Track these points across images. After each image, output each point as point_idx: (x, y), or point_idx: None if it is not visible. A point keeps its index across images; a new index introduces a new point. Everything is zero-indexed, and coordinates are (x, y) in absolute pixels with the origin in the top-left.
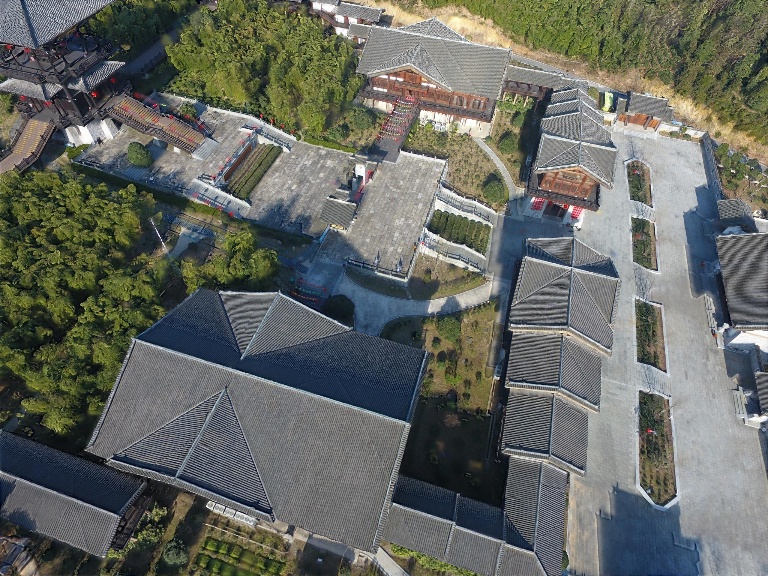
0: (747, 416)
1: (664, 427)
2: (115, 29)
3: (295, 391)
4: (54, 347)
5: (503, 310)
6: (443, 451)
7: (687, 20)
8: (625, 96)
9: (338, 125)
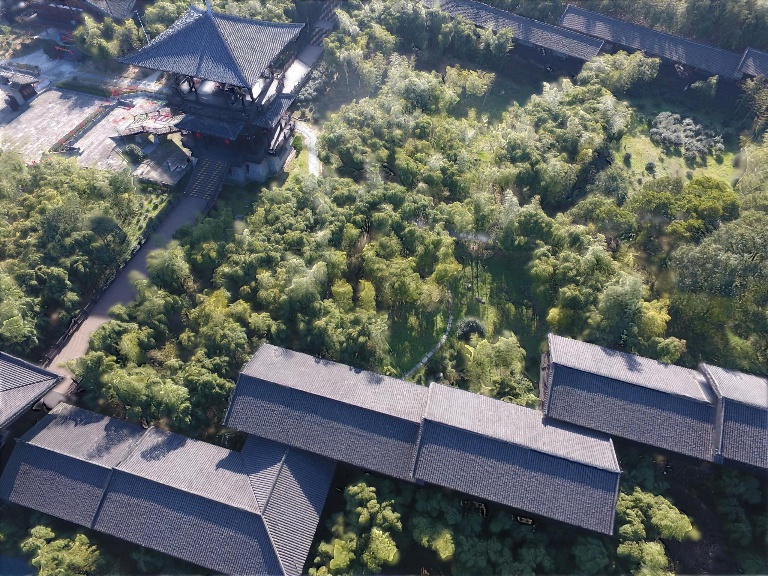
0: None
1: None
2: None
3: None
4: None
5: None
6: None
7: None
8: None
9: None
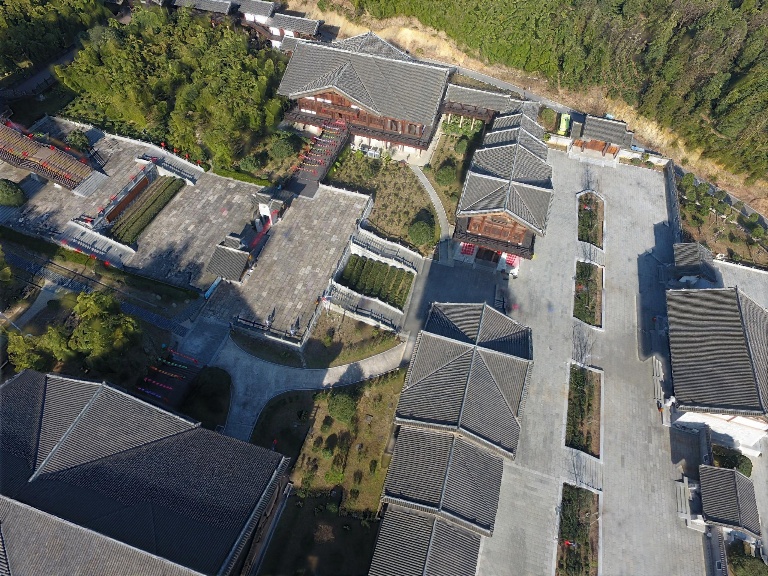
0: (690, 516)
1: (590, 531)
2: (7, 45)
3: (84, 530)
4: None
5: None
6: (315, 569)
7: (657, 33)
8: None
9: (256, 152)
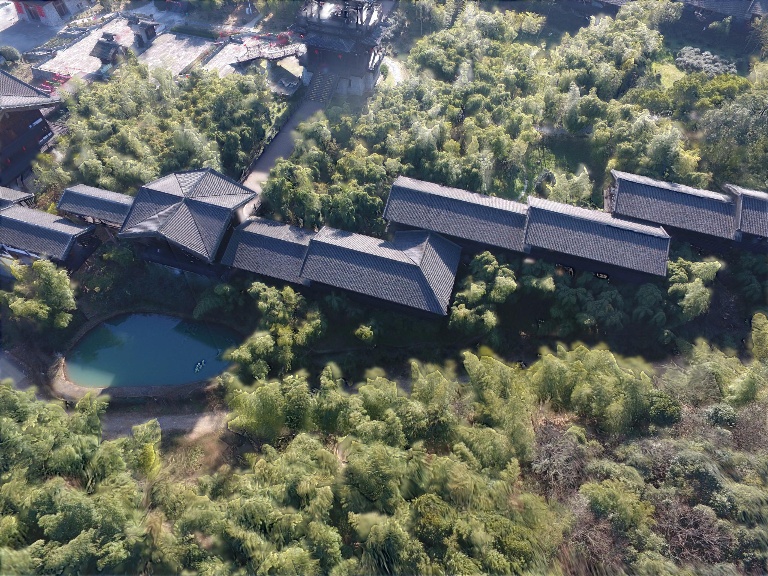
0: None
1: None
2: None
3: None
4: None
5: (68, 19)
6: None
7: None
8: None
9: None
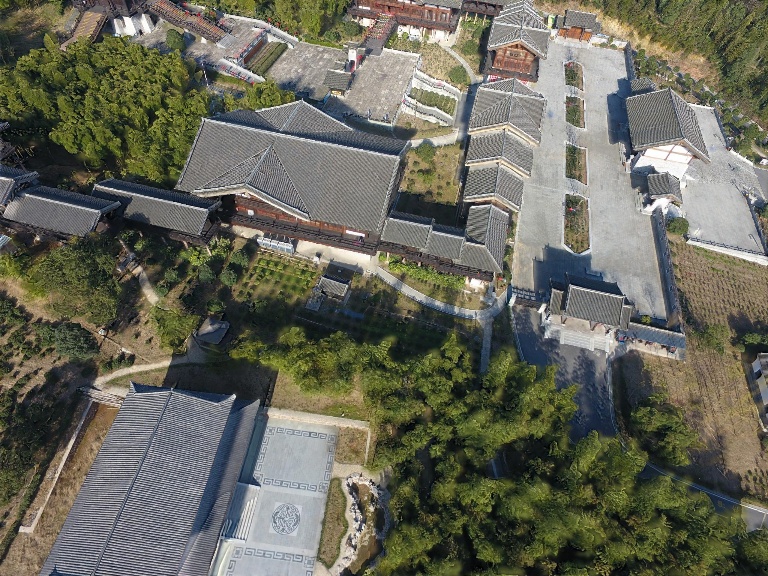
0: (643, 208)
1: (583, 214)
2: None
3: (320, 144)
4: (141, 134)
5: None
6: None
7: None
8: None
9: None
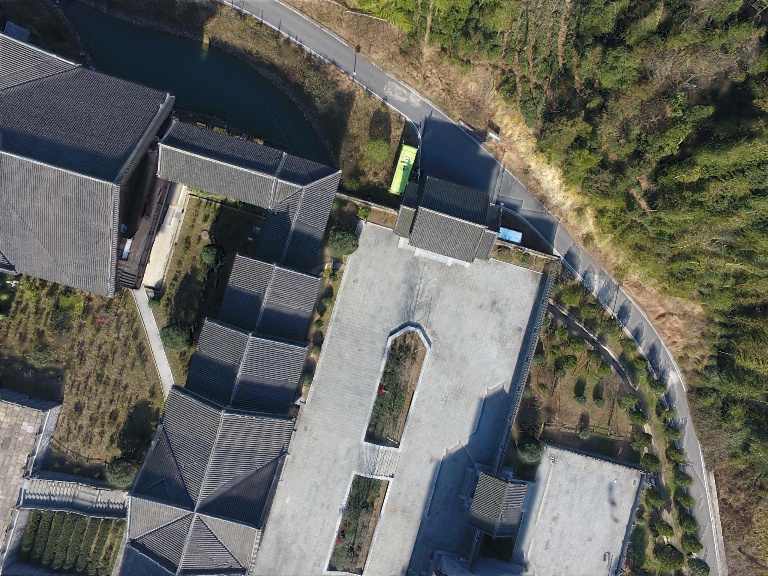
0: None
1: None
2: None
3: None
4: None
5: None
6: None
7: None
8: (455, 130)
9: None
